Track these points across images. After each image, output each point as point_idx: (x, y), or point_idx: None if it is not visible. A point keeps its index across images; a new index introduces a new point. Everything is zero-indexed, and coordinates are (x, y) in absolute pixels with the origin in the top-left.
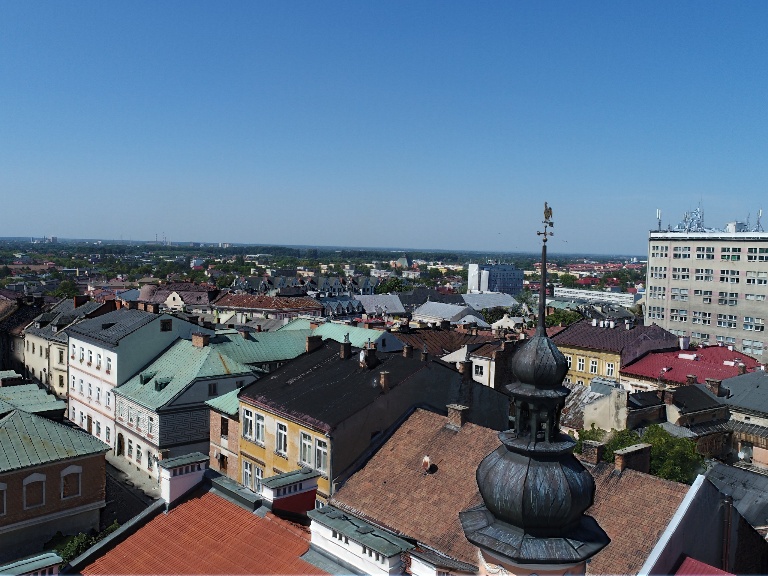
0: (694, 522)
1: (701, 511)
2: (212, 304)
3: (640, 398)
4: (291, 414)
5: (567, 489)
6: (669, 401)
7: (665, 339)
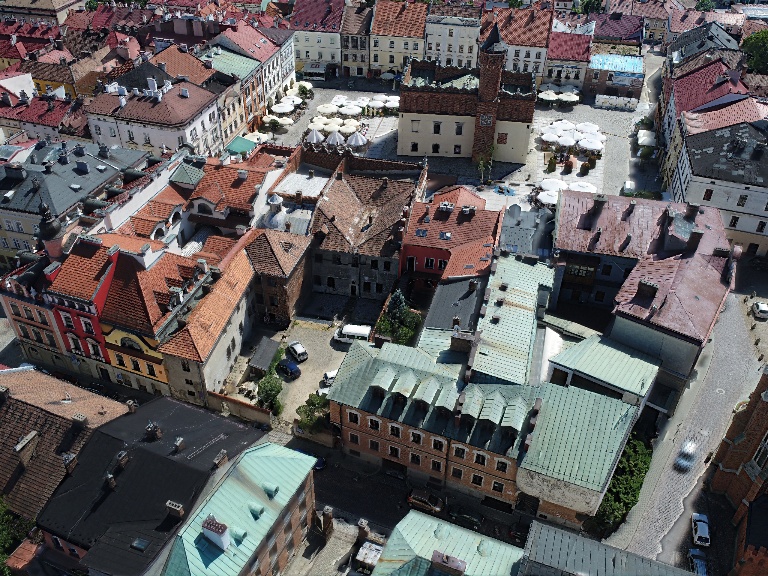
0: None
1: None
2: None
3: None
4: (203, 409)
5: None
6: None
7: None
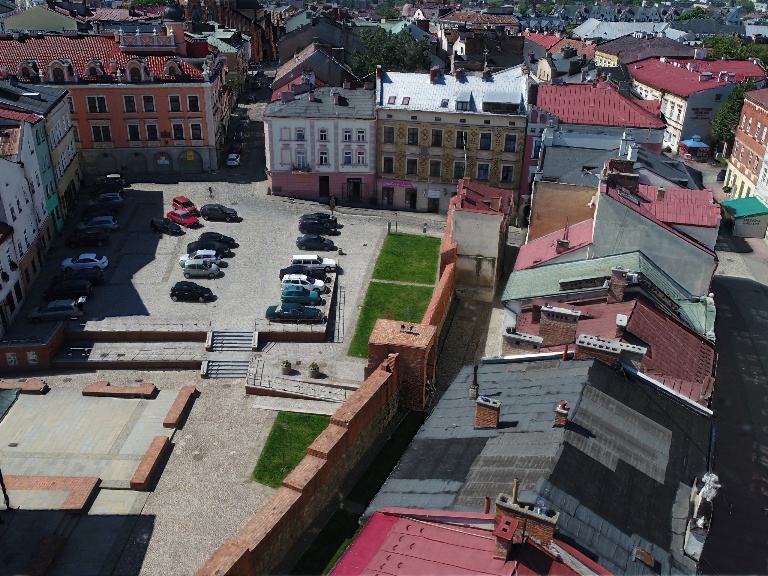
0: (312, 63)
1: (316, 60)
2: (440, 18)
3: (470, 57)
4: None
5: (169, 11)
6: (485, 60)
7: (676, 49)
